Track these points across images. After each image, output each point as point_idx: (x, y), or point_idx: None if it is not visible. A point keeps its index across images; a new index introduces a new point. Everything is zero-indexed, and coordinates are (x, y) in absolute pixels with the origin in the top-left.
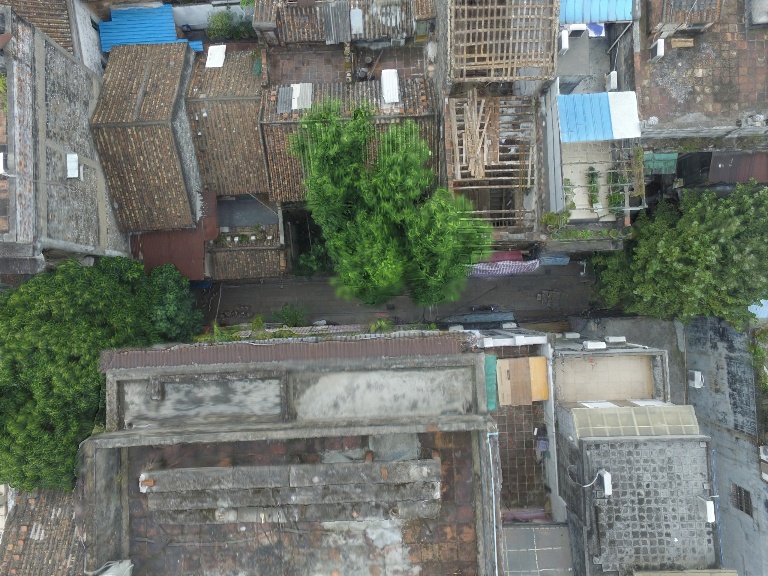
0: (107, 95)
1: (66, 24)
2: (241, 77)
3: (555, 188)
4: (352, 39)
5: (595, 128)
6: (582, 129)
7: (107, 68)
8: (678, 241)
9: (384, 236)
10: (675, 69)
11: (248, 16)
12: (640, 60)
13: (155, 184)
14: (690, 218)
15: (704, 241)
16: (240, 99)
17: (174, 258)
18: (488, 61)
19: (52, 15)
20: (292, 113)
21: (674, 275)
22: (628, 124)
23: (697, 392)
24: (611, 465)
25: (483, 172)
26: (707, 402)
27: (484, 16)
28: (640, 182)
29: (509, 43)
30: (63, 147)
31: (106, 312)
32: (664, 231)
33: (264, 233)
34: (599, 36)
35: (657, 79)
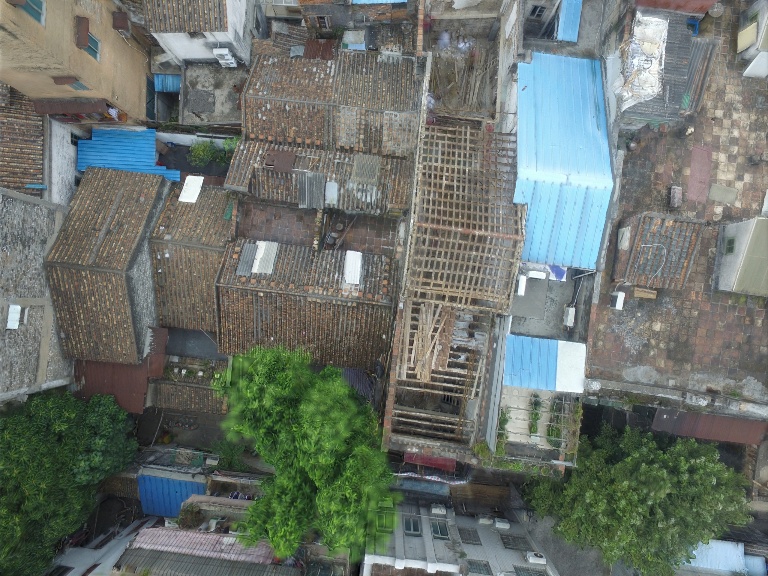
0: (70, 227)
1: (39, 150)
2: (211, 219)
3: (492, 421)
4: (325, 207)
5: (539, 376)
6: (526, 375)
7: (77, 193)
8: (608, 491)
9: (296, 484)
10: (634, 318)
11: (229, 156)
12: (600, 303)
13: (104, 323)
14: (626, 466)
15: (633, 499)
16: (204, 248)
17: (116, 388)
18: (444, 288)
19: (26, 141)
20: (251, 277)
21: (599, 523)
22: (573, 377)
23: None
24: None
25: (429, 377)
26: None
27: (445, 247)
28: (574, 440)
29: (467, 275)
30: (7, 298)
31: (21, 475)
32: (599, 469)
33: (213, 369)
34: (560, 280)
35: (614, 325)
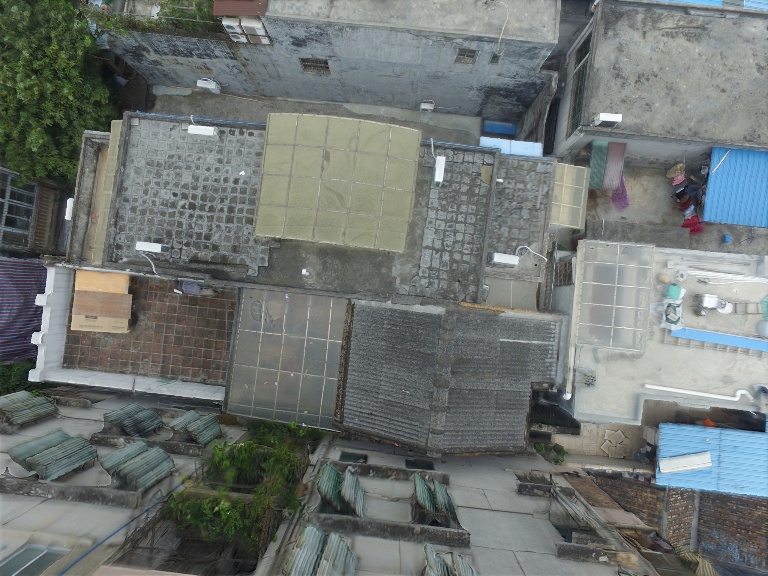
0: None
1: None
2: None
3: None
4: None
5: None
6: None
7: None
8: None
9: None
10: None
11: None
12: None
13: None
14: None
15: None
16: None
17: None
18: None
19: None
20: None
21: (11, 104)
22: None
23: (226, 86)
24: (143, 234)
25: None
26: (230, 79)
27: None
28: None
29: None
30: None
31: None
32: None
33: None
34: None
35: None
